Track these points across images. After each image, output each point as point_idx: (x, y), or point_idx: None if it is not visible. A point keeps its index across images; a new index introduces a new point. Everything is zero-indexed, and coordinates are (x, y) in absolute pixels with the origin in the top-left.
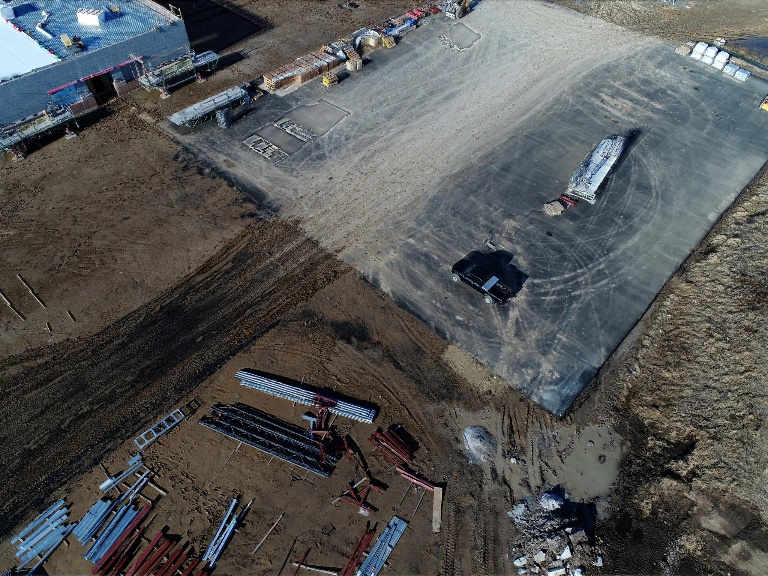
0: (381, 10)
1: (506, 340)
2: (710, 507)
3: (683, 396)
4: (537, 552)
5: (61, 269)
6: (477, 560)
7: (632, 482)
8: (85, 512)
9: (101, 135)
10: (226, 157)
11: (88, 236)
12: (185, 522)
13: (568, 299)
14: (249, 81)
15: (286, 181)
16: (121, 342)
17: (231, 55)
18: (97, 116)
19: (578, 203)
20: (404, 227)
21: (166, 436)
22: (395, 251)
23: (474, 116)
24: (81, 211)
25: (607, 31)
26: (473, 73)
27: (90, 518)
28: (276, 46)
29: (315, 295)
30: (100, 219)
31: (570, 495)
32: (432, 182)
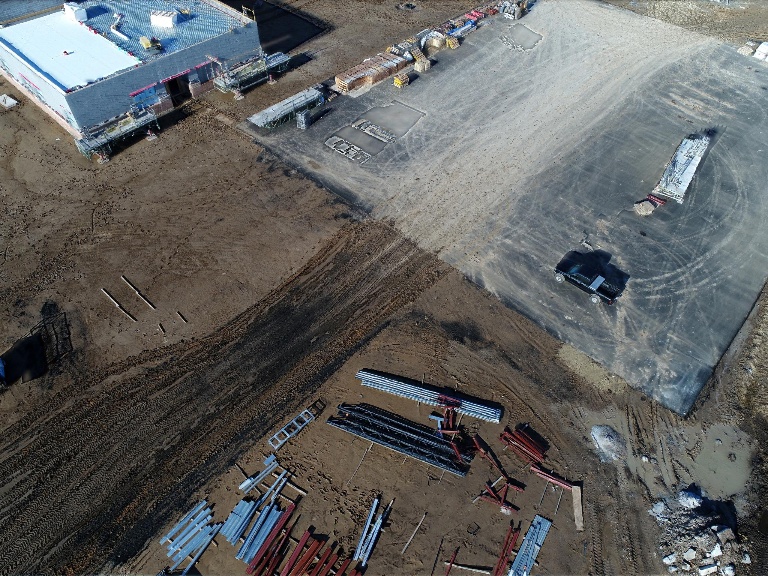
0: (438, 11)
1: (618, 339)
2: None
3: None
4: (686, 550)
5: (164, 270)
6: (625, 558)
7: (767, 480)
8: (229, 512)
9: (181, 137)
10: (310, 158)
11: (185, 237)
12: (330, 522)
13: (673, 298)
14: (320, 82)
15: (374, 182)
16: (236, 343)
17: (297, 56)
18: (175, 118)
19: (666, 203)
20: (499, 227)
21: (297, 436)
22: (494, 251)
23: (549, 116)
24: (174, 213)
25: (667, 31)
26: (541, 74)
27: (235, 518)
28: (340, 47)
29: (421, 295)
30: (194, 220)
31: (707, 493)
32: (519, 182)
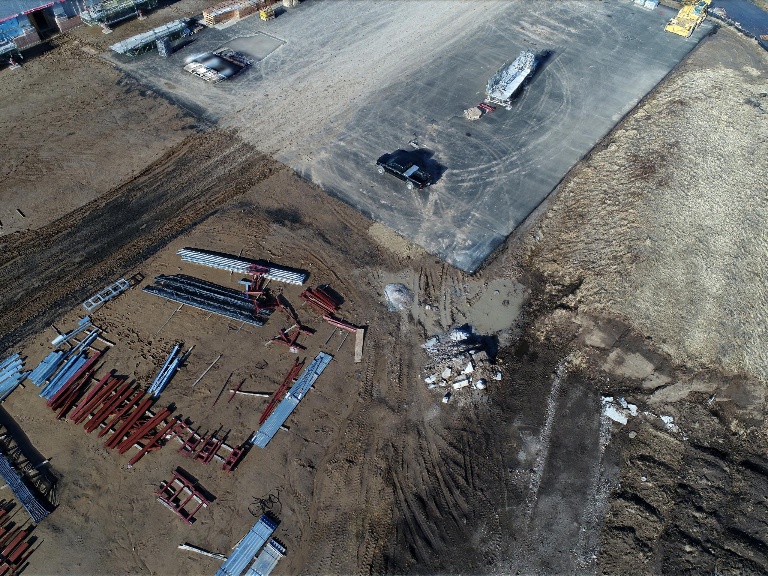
0: None
1: (425, 217)
2: (592, 326)
3: (577, 249)
4: (444, 370)
5: (9, 176)
6: (393, 381)
7: (530, 318)
8: (39, 362)
9: (45, 66)
10: (167, 80)
11: (35, 149)
12: (131, 365)
13: (482, 184)
14: (189, 18)
15: (225, 98)
16: (69, 232)
17: None
18: (40, 50)
19: (496, 110)
20: (335, 132)
21: (113, 302)
22: (326, 151)
23: (403, 42)
24: (27, 129)
25: None
26: (404, 7)
27: (43, 366)
28: None
29: (251, 189)
30: (46, 135)
31: (476, 330)
32: (362, 96)
